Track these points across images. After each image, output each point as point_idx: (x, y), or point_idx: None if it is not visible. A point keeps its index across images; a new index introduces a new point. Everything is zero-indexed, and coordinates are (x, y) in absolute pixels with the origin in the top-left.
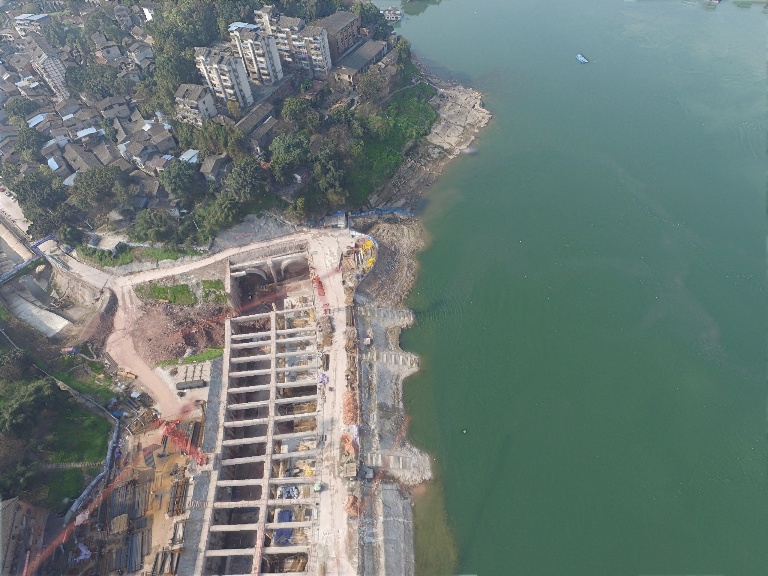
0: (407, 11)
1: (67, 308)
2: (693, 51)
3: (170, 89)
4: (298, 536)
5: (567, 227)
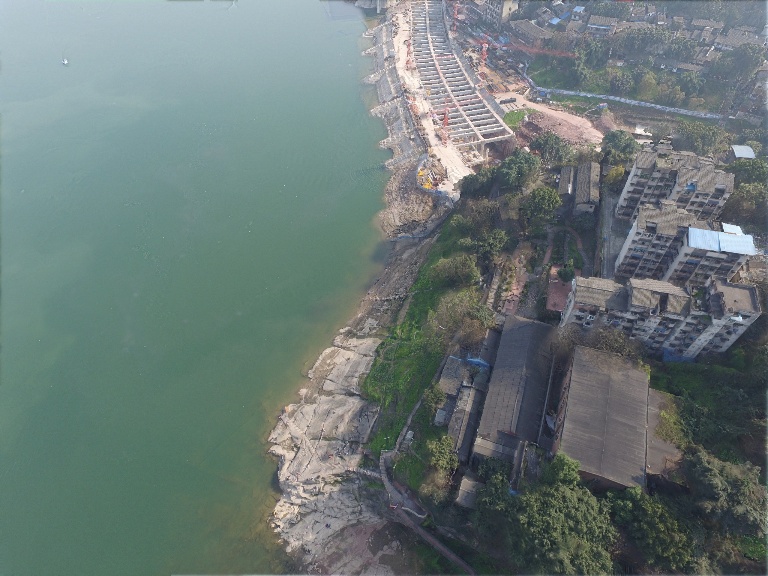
0: None
1: None
2: None
3: None
4: None
5: (242, 242)
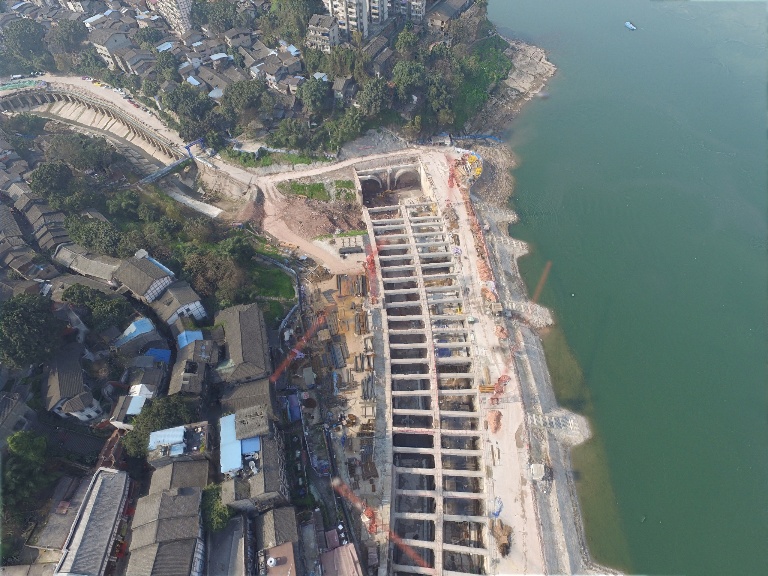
0: None
1: (215, 202)
2: (729, 23)
3: (300, 19)
4: (456, 356)
5: (636, 155)
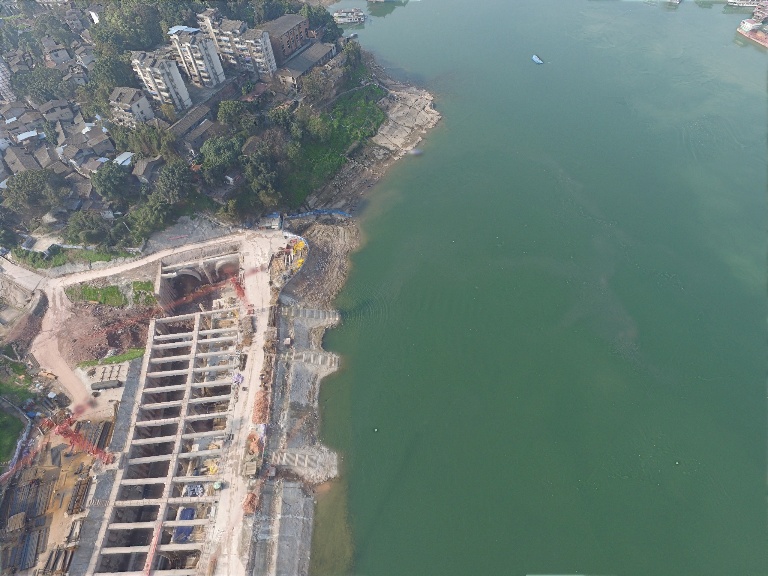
0: (373, 13)
1: (0, 310)
2: (646, 52)
3: (106, 92)
4: (197, 534)
5: (501, 227)
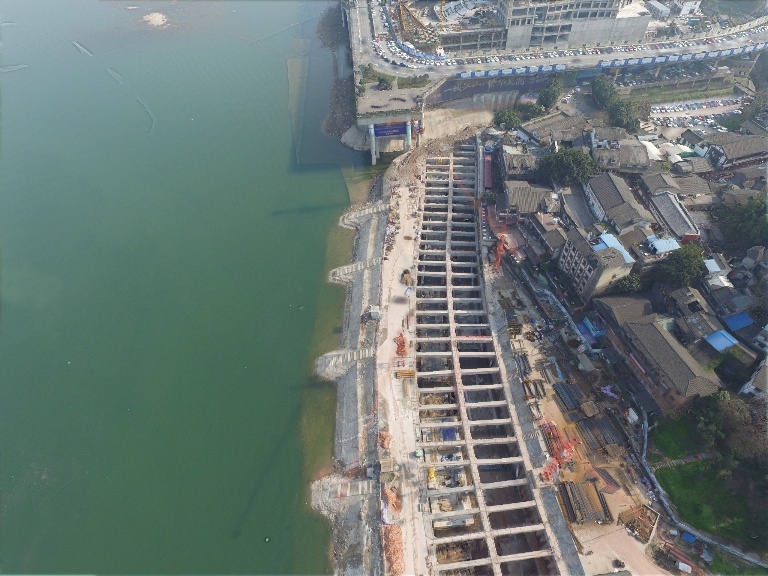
0: None
1: None
2: None
3: None
4: None
5: None
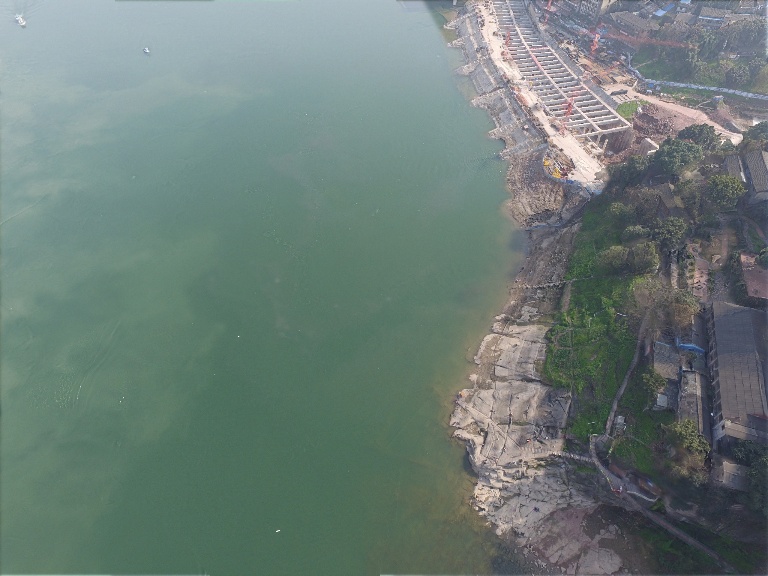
0: None
1: None
2: None
3: None
4: None
5: (373, 229)
